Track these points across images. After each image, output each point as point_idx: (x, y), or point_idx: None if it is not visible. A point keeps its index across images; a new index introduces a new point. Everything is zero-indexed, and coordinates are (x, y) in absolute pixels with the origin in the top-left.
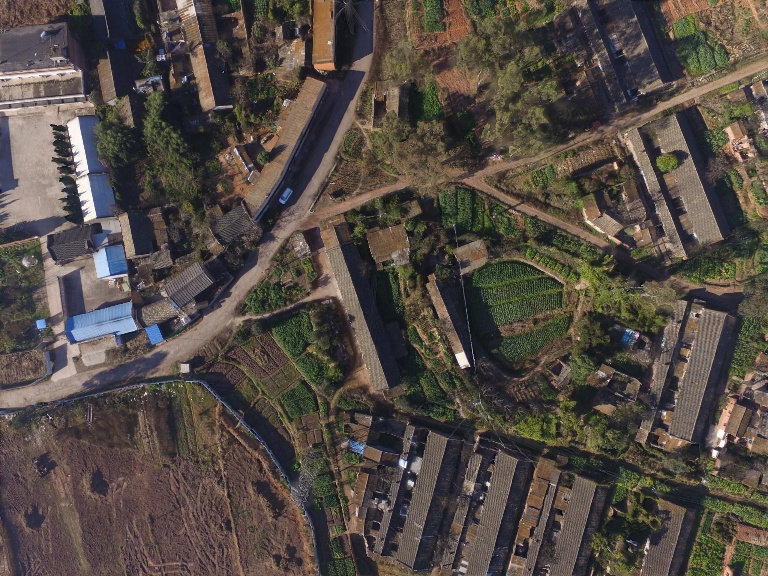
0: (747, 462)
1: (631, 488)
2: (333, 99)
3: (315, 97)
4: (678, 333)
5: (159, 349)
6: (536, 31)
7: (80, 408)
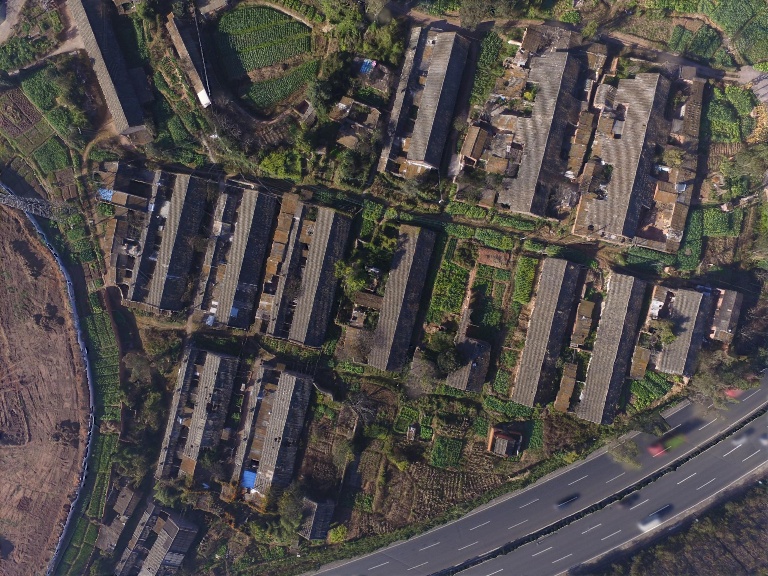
0: None
1: (376, 220)
2: None
3: None
4: (413, 59)
5: None
6: None
7: None
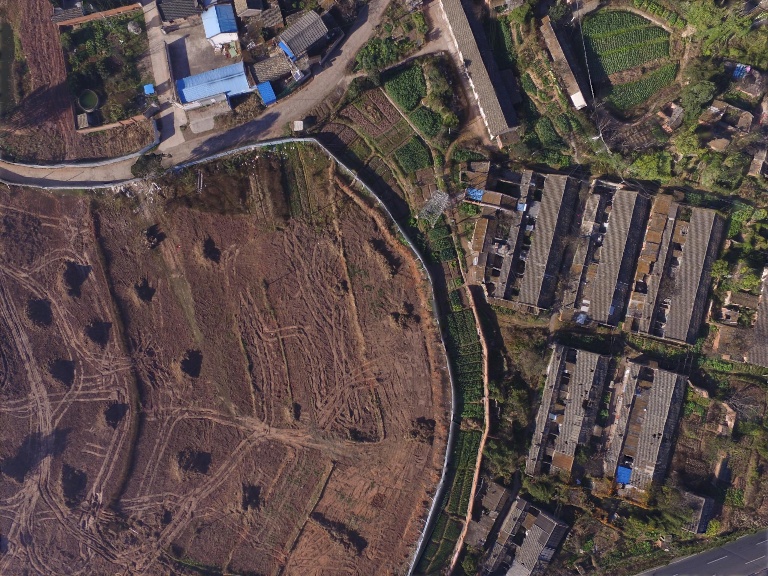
0: None
1: (746, 221)
2: None
3: None
4: None
5: (270, 111)
6: None
7: (190, 174)
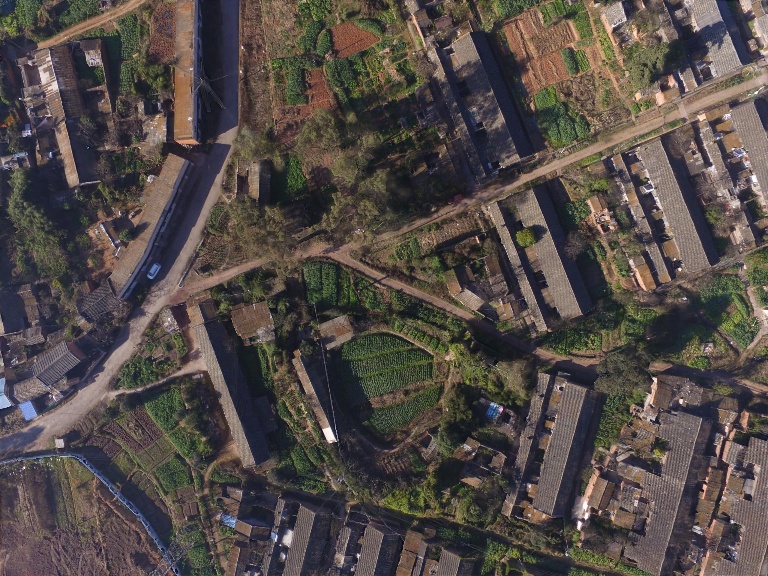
0: (609, 535)
1: (498, 559)
2: (199, 173)
3: (176, 174)
4: (541, 407)
5: (35, 424)
6: (399, 102)
7: None
